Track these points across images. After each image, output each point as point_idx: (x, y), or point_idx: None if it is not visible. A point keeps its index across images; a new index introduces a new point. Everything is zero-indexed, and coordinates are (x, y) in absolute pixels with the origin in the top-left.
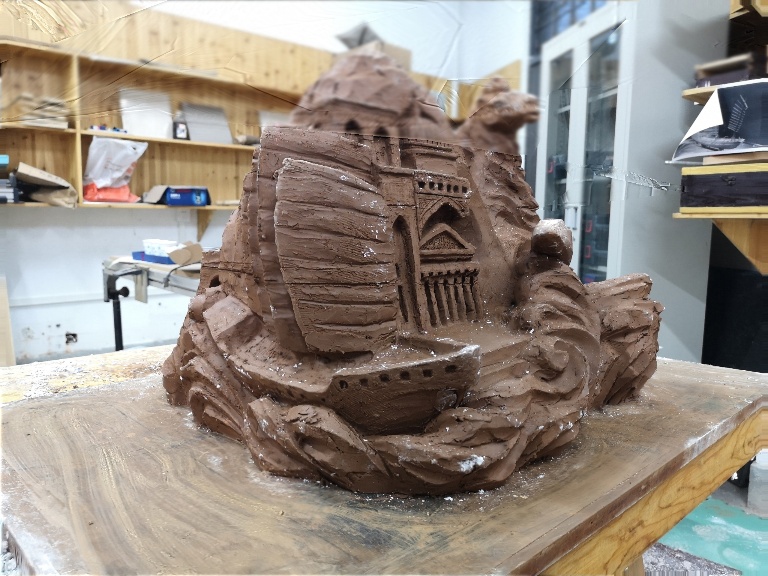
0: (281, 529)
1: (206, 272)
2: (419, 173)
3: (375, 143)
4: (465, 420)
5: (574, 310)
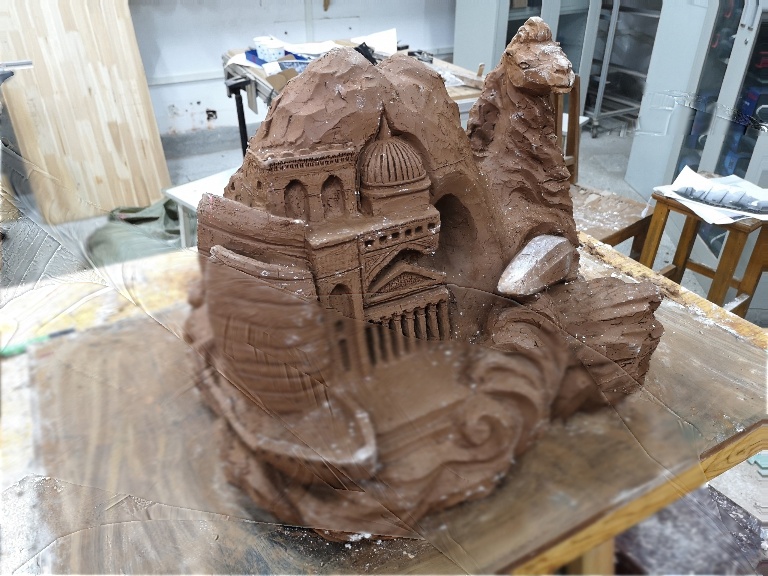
0: (208, 559)
1: None
2: (365, 234)
3: (328, 188)
4: None
5: None
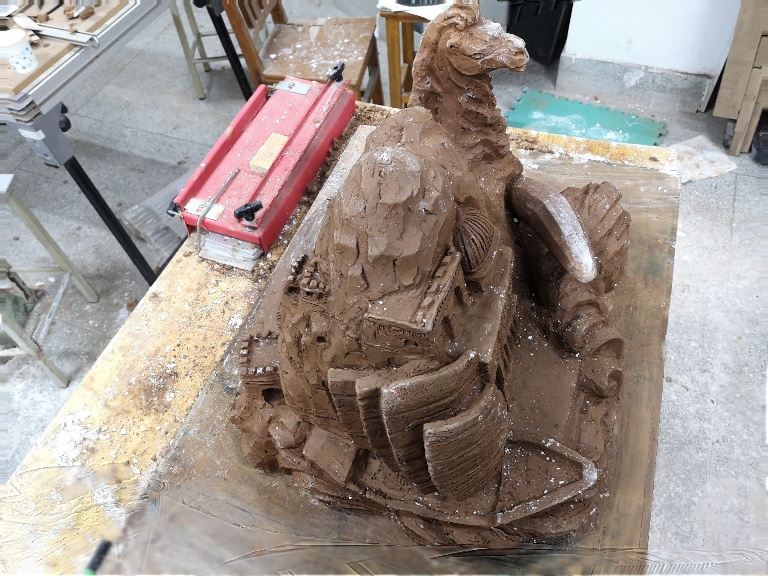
0: None
1: (253, 386)
2: None
3: None
4: (584, 500)
5: (592, 300)
